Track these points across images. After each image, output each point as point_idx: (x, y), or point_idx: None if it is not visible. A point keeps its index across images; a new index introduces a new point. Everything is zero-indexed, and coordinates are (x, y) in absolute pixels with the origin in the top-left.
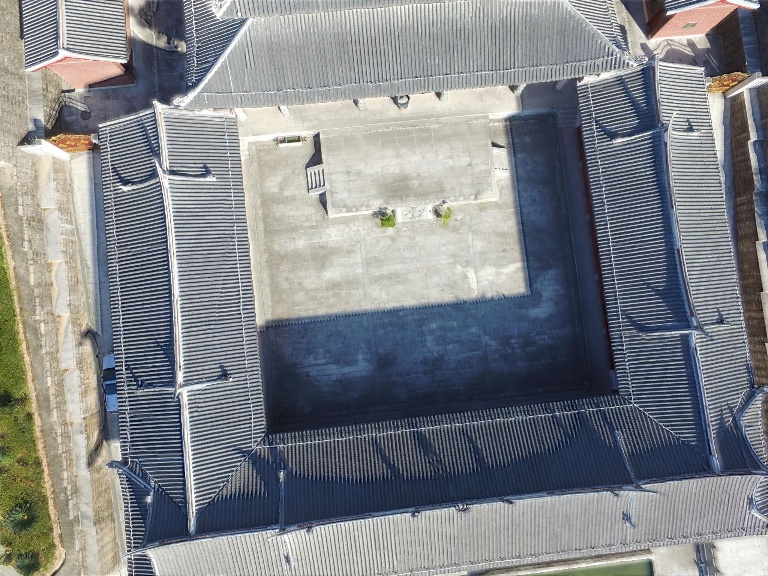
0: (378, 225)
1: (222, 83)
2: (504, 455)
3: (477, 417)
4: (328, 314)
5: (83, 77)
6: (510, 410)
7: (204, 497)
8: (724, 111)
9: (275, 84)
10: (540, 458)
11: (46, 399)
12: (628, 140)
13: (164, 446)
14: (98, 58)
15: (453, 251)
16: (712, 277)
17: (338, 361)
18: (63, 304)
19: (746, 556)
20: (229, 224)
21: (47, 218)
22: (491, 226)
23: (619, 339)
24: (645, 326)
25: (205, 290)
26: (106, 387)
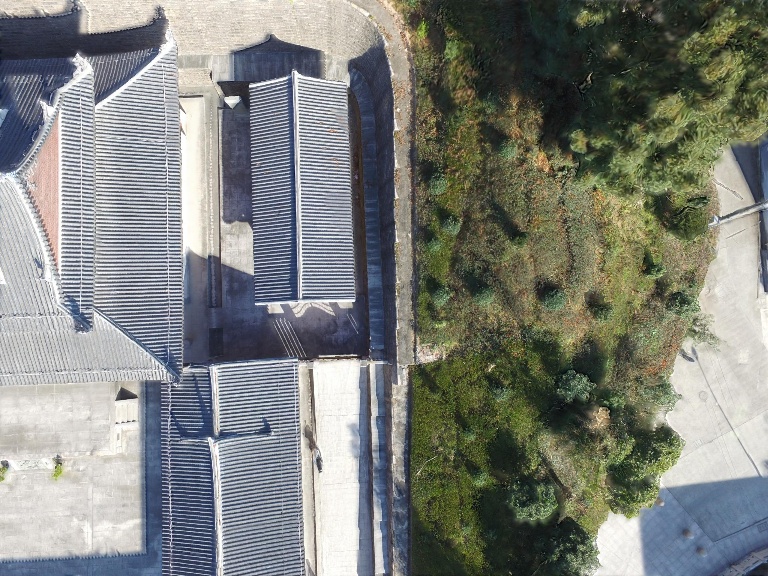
0: None
1: None
2: None
3: None
4: None
5: None
6: None
7: None
8: (360, 375)
9: None
10: None
11: None
12: (193, 441)
13: None
14: None
15: (71, 503)
16: None
17: None
18: None
19: None
20: None
21: None
22: (113, 479)
23: None
24: None
25: None
26: None
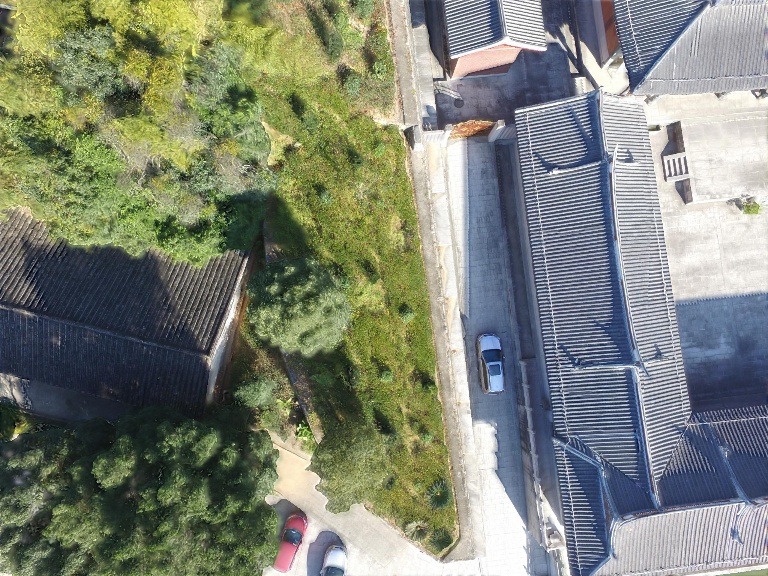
0: (733, 212)
1: (667, 70)
2: None
3: None
4: (690, 298)
5: (475, 65)
6: None
7: (656, 472)
8: None
9: (711, 72)
10: None
11: (447, 379)
12: None
13: (610, 422)
14: (527, 46)
15: None
16: None
17: (702, 344)
18: (453, 286)
19: None
20: (649, 208)
21: (436, 202)
22: None
23: None
24: None
25: (638, 271)
26: (490, 368)
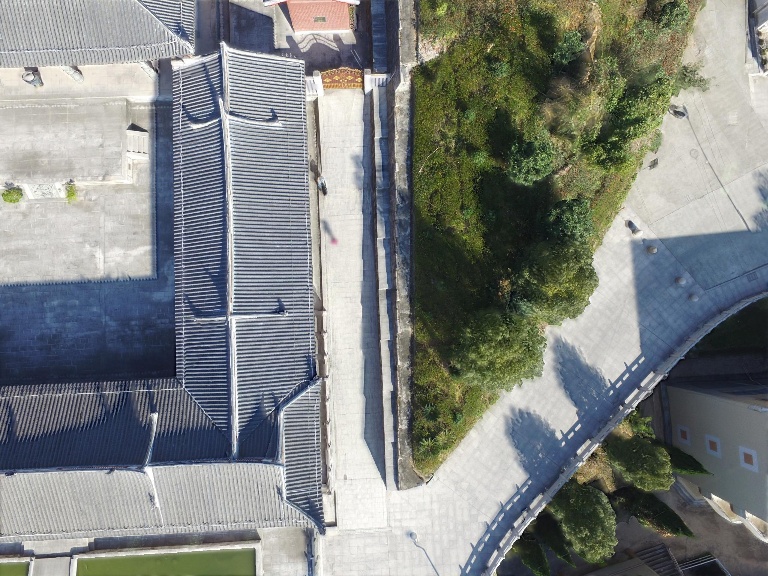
0: None
1: None
2: (37, 429)
3: (27, 391)
4: None
5: None
6: (62, 386)
7: None
8: (364, 108)
9: None
10: (70, 434)
11: None
12: (204, 127)
13: None
14: None
15: (83, 230)
16: (277, 267)
17: None
18: None
19: (373, 554)
20: None
21: None
22: (125, 208)
23: (181, 323)
24: (201, 311)
25: None
26: None
